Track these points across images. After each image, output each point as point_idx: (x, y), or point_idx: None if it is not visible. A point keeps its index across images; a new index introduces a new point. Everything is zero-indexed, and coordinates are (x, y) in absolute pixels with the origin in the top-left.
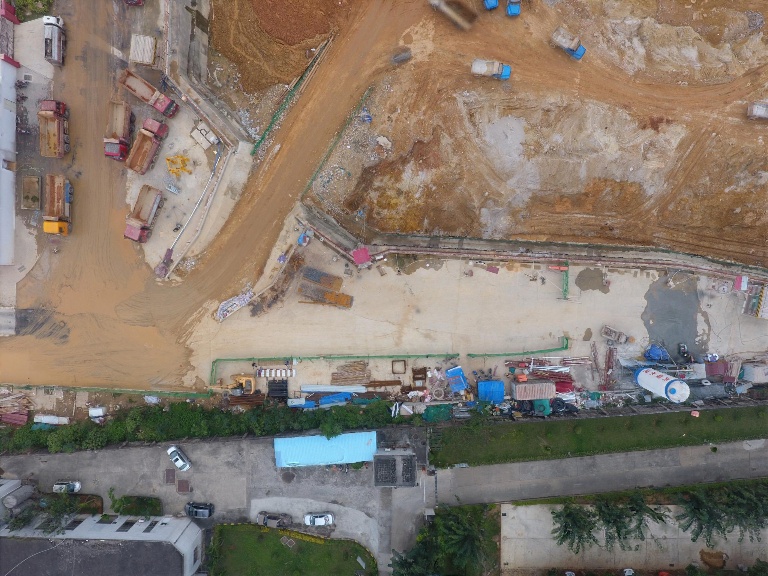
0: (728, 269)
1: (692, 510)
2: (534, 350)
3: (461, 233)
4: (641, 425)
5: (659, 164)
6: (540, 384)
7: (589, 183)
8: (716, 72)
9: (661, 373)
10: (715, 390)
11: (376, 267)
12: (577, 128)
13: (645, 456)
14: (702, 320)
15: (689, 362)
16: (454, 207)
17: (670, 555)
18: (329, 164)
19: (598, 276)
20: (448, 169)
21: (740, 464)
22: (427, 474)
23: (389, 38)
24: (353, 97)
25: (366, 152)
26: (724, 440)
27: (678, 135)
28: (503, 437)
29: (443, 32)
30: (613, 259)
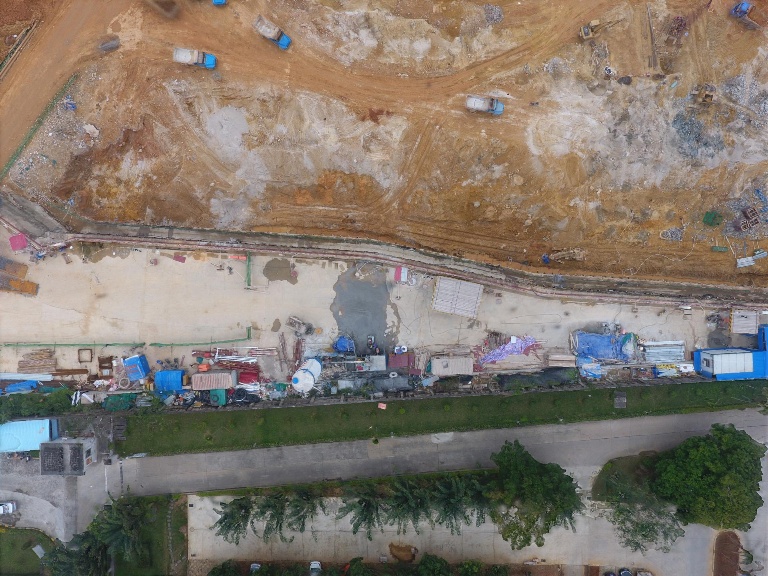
0: (440, 262)
1: (352, 502)
2: (221, 340)
3: (191, 223)
4: (327, 417)
5: (383, 156)
6: (216, 374)
7: (320, 175)
8: (437, 64)
9: (309, 363)
10: (398, 382)
11: (61, 255)
12: (298, 119)
13: (333, 448)
14: (391, 312)
15: (374, 354)
16: (174, 197)
17: (359, 548)
18: (28, 151)
19: (286, 267)
20: (167, 158)
21: (428, 457)
22: (104, 463)
23: (96, 26)
24: (56, 84)
25: (74, 140)
26: (409, 433)
27: (399, 127)
28: (189, 427)
29: (151, 20)
30: (302, 250)
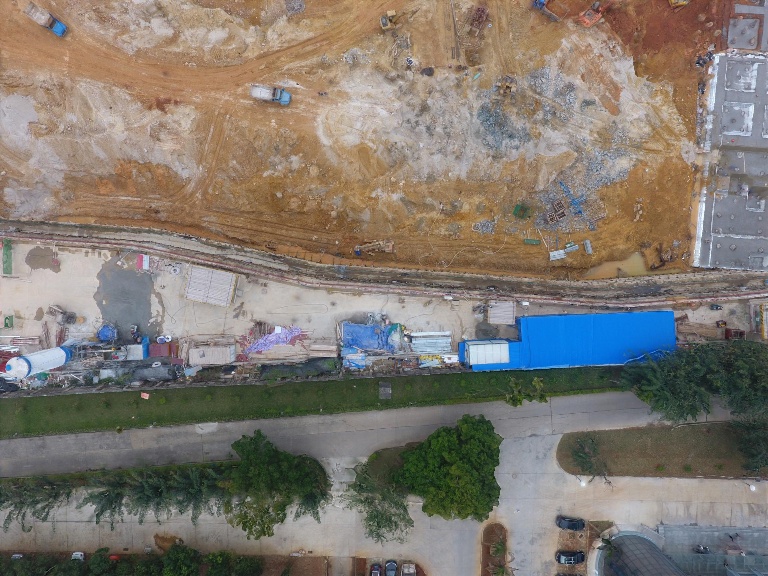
0: (222, 252)
1: None
2: None
3: None
4: (90, 407)
5: (174, 146)
6: None
7: (116, 164)
8: (225, 54)
9: (41, 351)
10: (158, 372)
11: None
12: (86, 108)
13: (96, 438)
14: (156, 301)
15: (135, 343)
16: None
17: (124, 539)
18: None
19: (49, 255)
20: None
21: (192, 448)
22: None
23: None
24: None
25: None
26: (171, 423)
27: (188, 117)
28: None
29: None
30: (65, 238)
